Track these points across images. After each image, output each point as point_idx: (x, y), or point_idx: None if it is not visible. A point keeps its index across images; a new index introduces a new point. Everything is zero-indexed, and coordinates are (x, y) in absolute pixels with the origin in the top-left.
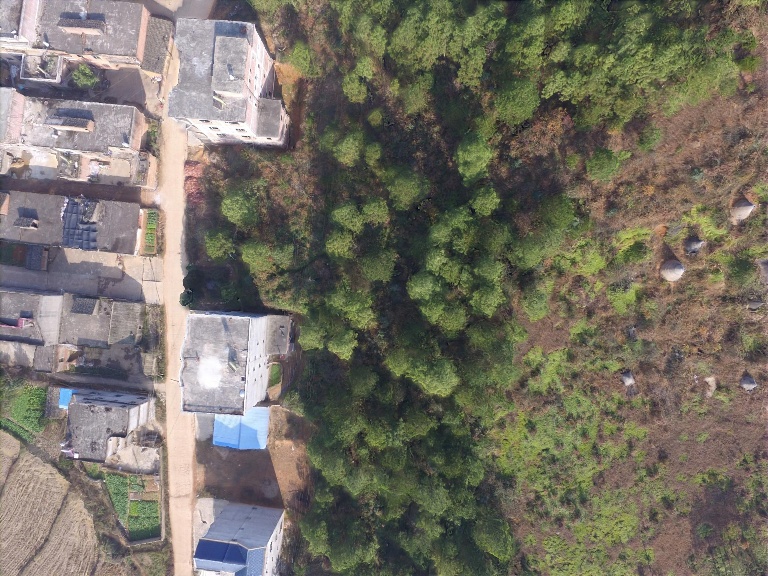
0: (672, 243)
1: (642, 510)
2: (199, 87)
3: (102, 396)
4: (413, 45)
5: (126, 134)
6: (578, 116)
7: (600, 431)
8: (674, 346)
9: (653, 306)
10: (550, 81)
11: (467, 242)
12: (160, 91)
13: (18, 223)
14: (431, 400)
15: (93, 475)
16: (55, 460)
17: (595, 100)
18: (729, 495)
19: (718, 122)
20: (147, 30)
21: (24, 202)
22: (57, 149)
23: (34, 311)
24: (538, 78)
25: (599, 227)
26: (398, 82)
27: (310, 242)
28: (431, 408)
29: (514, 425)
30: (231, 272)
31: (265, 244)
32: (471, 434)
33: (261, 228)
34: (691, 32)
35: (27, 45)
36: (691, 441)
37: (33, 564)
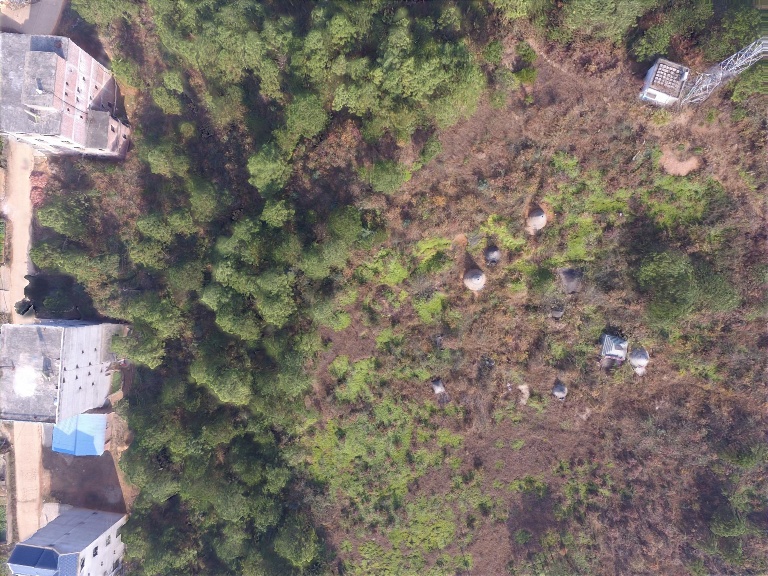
0: (474, 253)
1: (459, 516)
2: (15, 101)
3: None
4: (214, 58)
5: None
6: (363, 128)
7: (413, 438)
8: (484, 354)
9: (457, 315)
10: (336, 94)
11: (255, 253)
12: None
13: None
14: (240, 408)
15: None
16: None
17: (374, 113)
18: (546, 502)
19: (501, 133)
20: None
21: None
22: None
23: None
24: (328, 90)
25: (397, 237)
26: (210, 94)
27: None
28: (239, 416)
29: (324, 433)
30: (74, 281)
31: (92, 254)
32: (276, 442)
33: (94, 238)
34: (452, 46)
35: None
36: (507, 448)
37: None
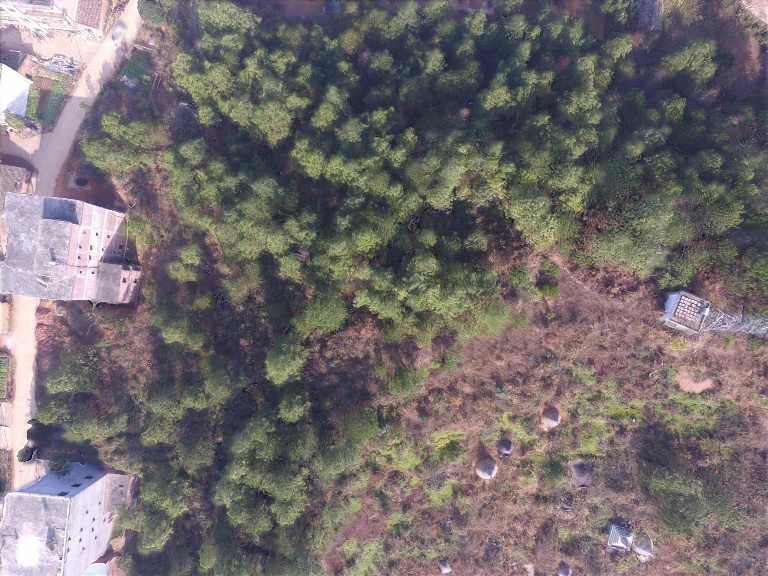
0: (487, 443)
1: None
2: (26, 264)
3: None
4: (234, 240)
5: None
6: (384, 332)
7: None
8: (491, 536)
9: (468, 502)
10: (358, 295)
11: None
12: None
13: None
14: None
15: None
16: None
17: (397, 322)
18: None
19: (521, 343)
20: None
21: None
22: None
23: None
24: (349, 288)
25: (412, 429)
26: (227, 267)
27: (146, 409)
28: None
29: None
30: None
31: (99, 412)
32: None
33: (102, 389)
34: (479, 275)
35: None
36: None
37: None
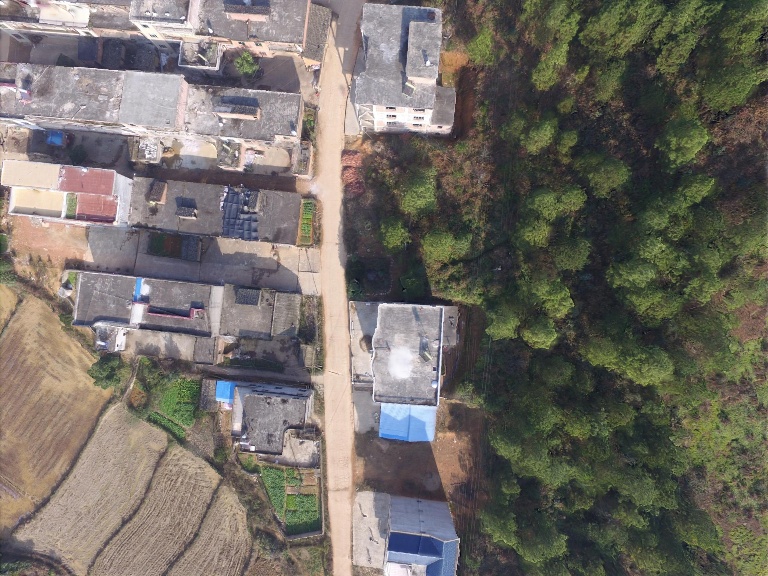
0: None
1: None
2: (387, 73)
3: (265, 388)
4: (614, 31)
5: (293, 122)
6: None
7: None
8: None
9: None
10: (766, 67)
11: (682, 229)
12: (319, 79)
13: (180, 213)
14: (626, 390)
15: (249, 469)
16: (205, 454)
17: None
18: None
19: None
20: (308, 17)
21: (182, 192)
22: (221, 137)
23: (205, 302)
24: (750, 64)
25: None
26: (588, 69)
27: (486, 231)
28: (626, 398)
29: (707, 415)
30: (391, 263)
31: (442, 233)
32: None
33: (431, 218)
34: None
35: (191, 32)
36: None
37: (183, 559)
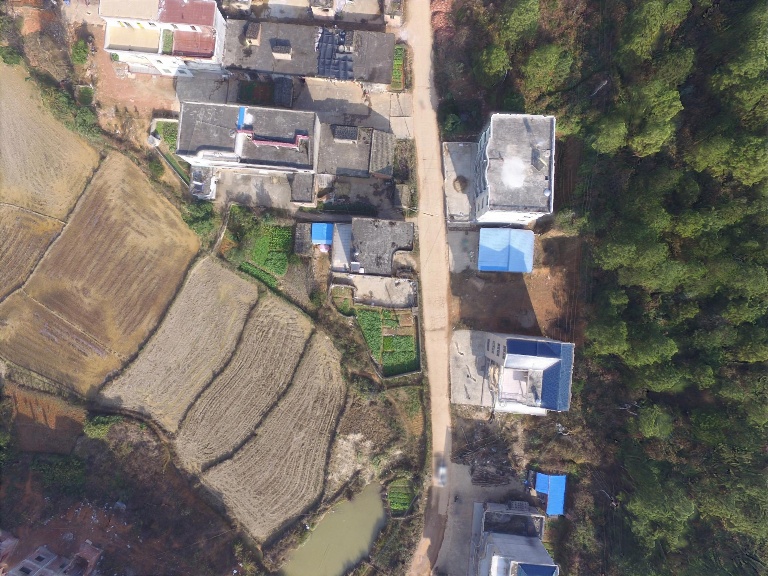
0: None
1: None
2: None
3: None
4: None
5: None
6: None
7: None
8: None
9: None
10: None
11: None
12: None
13: (277, 50)
14: (730, 196)
15: (345, 312)
16: (298, 302)
17: None
18: None
19: None
20: None
21: (276, 33)
22: None
23: (309, 130)
24: None
25: None
26: None
27: (583, 60)
28: None
29: None
30: (483, 104)
31: None
32: None
33: (527, 51)
34: None
35: None
36: None
37: (277, 409)
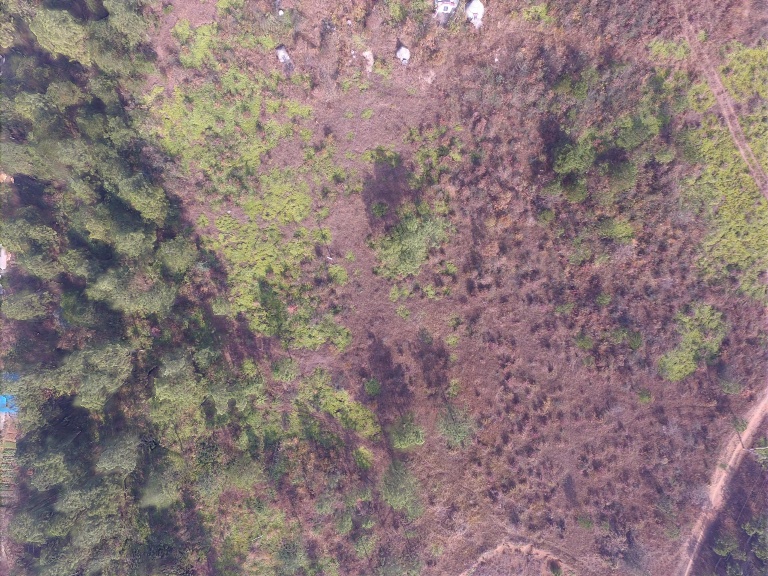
0: None
1: (313, 189)
2: None
3: None
4: None
5: None
6: None
7: (262, 108)
8: (324, 18)
9: None
10: None
11: None
12: None
13: None
14: None
15: None
16: None
17: None
18: (399, 170)
19: None
20: None
21: None
22: None
23: None
24: None
25: None
26: None
27: None
28: None
29: (171, 101)
30: None
31: None
32: (122, 104)
33: None
34: None
35: None
36: (356, 118)
37: None
